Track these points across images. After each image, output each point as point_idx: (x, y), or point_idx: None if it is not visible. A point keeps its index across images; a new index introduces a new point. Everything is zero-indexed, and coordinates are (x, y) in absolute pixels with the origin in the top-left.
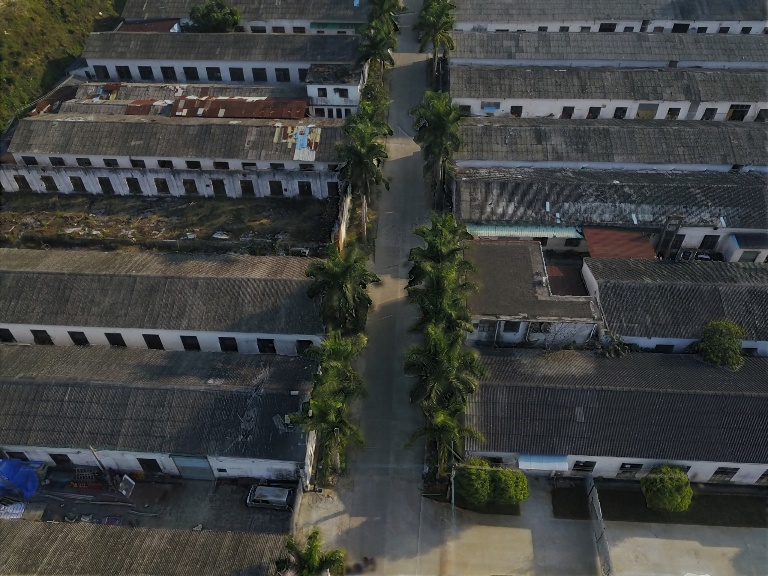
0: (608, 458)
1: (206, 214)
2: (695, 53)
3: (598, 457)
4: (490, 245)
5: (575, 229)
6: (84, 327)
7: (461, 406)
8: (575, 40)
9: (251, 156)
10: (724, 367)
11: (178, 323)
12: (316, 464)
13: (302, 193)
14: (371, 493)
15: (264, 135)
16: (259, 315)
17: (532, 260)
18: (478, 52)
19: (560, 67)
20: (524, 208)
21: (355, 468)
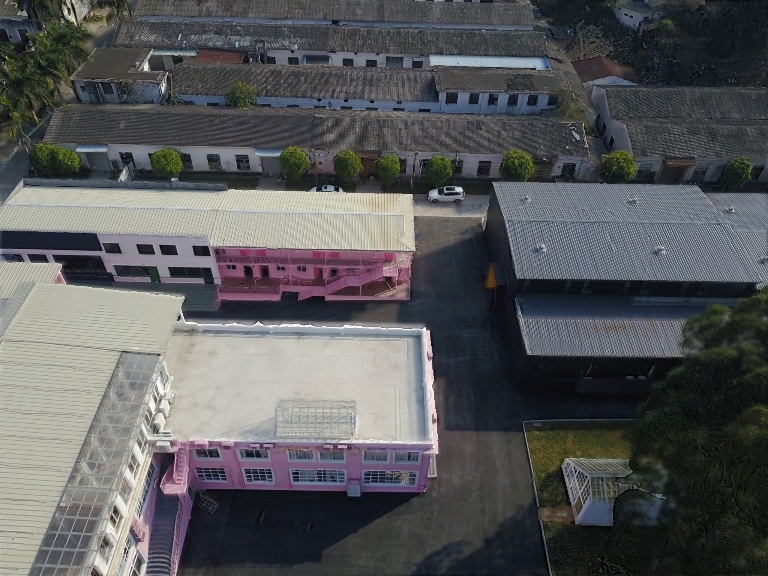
0: (134, 147)
1: None
2: None
3: (127, 145)
4: (116, 50)
5: (196, 51)
6: None
7: (19, 98)
8: None
9: None
10: (235, 108)
11: None
12: None
13: (24, 40)
14: None
15: None
16: None
17: (139, 56)
18: None
19: None
20: (163, 38)
21: None
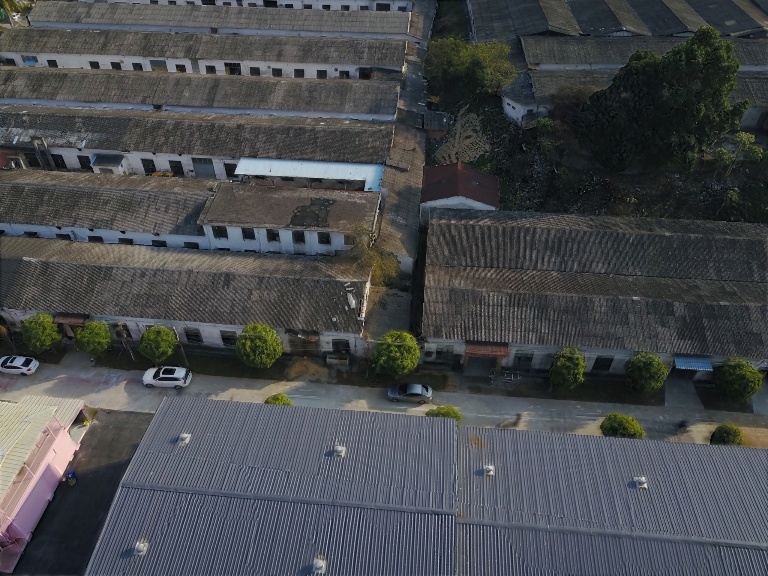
0: None
1: None
2: (233, 22)
3: None
4: None
5: None
6: None
7: None
8: (138, 9)
9: None
10: None
11: None
12: None
13: None
14: None
15: None
16: None
17: None
18: (53, 17)
19: (110, 30)
20: None
21: None
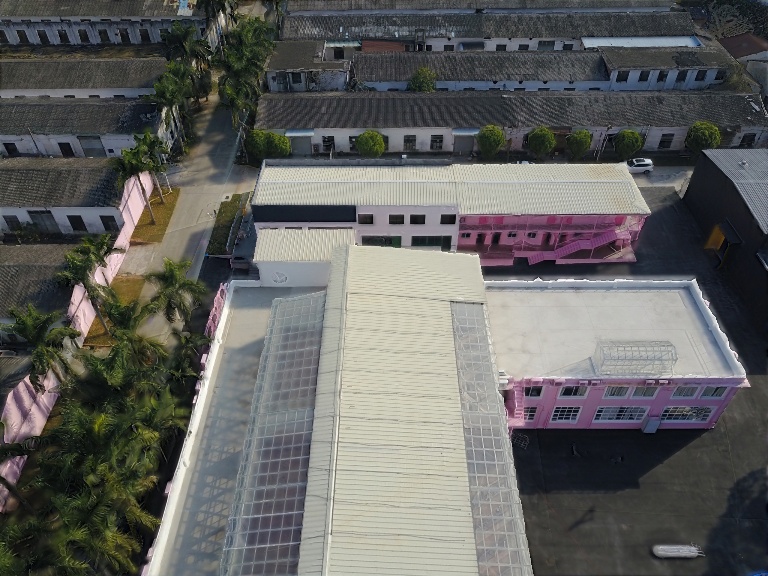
0: (338, 130)
1: (115, 52)
2: None
3: (332, 129)
4: (293, 42)
5: (358, 42)
6: (25, 90)
7: (241, 87)
8: None
9: (147, 14)
10: (420, 92)
11: (86, 85)
12: (172, 154)
13: None
14: (203, 163)
15: (157, 1)
16: (139, 79)
17: (317, 48)
18: None
19: None
20: (325, 31)
21: (195, 155)
